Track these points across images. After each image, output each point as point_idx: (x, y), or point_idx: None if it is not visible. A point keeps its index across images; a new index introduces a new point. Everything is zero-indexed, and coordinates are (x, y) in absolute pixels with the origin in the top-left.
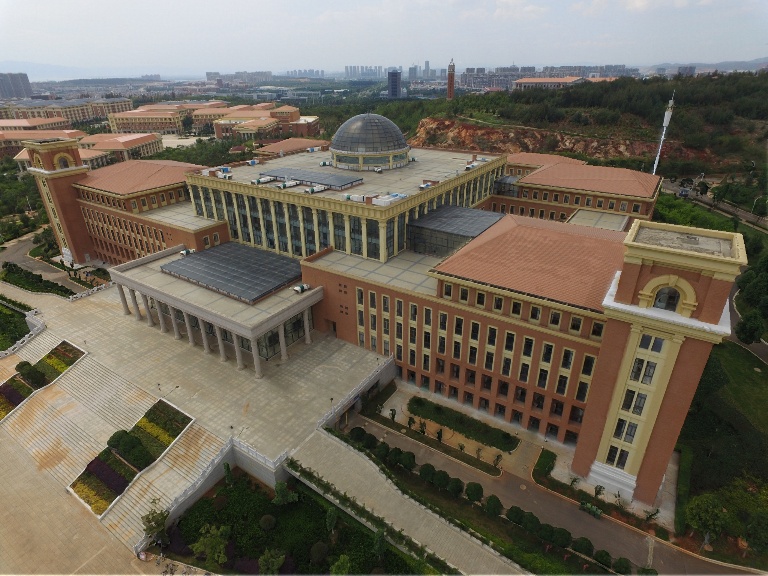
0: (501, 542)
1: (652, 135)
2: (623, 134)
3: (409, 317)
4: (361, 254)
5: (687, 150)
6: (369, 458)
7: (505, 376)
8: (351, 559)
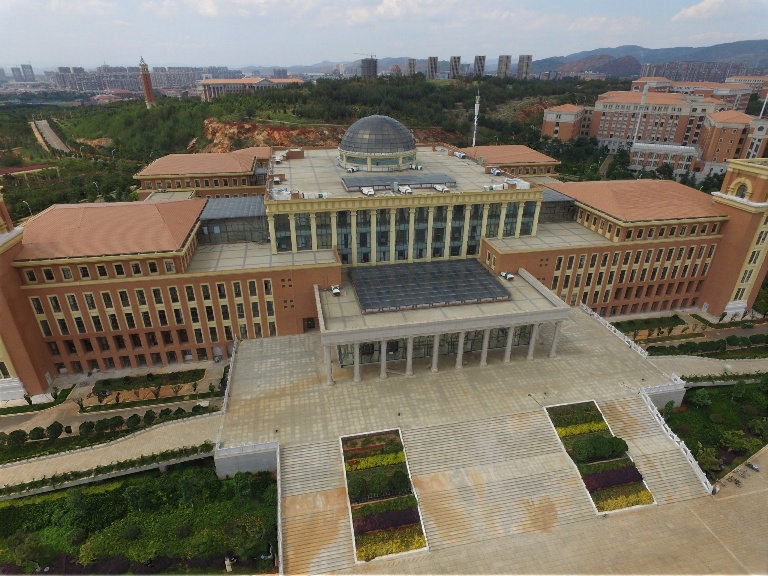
0: (766, 355)
1: (422, 124)
2: (405, 125)
3: (600, 265)
4: (512, 235)
5: (447, 133)
6: (687, 355)
7: (663, 280)
8: (762, 401)
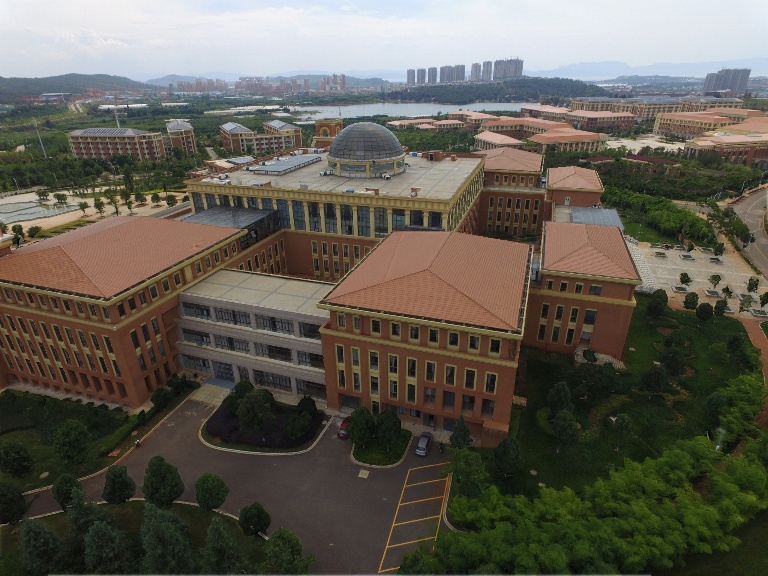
0: None
1: None
2: None
3: None
4: None
5: None
6: None
7: None
8: None
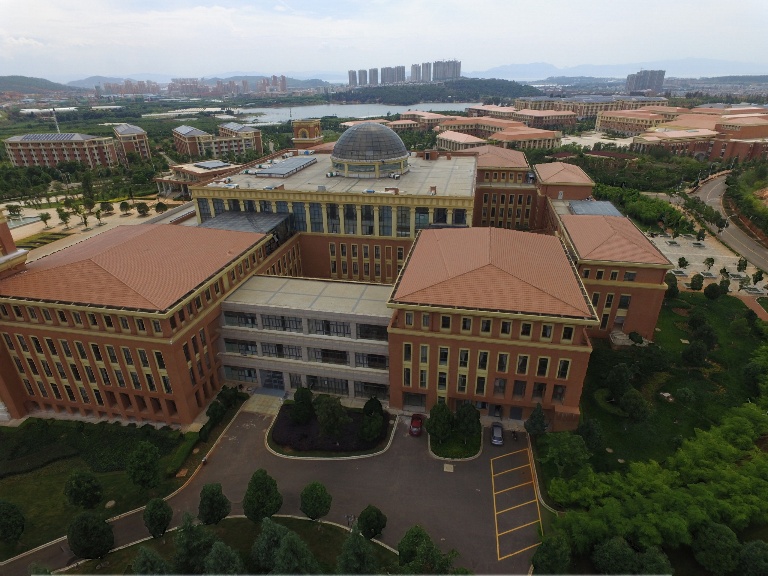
0: None
1: None
2: None
3: None
4: None
5: None
6: None
7: None
8: None
